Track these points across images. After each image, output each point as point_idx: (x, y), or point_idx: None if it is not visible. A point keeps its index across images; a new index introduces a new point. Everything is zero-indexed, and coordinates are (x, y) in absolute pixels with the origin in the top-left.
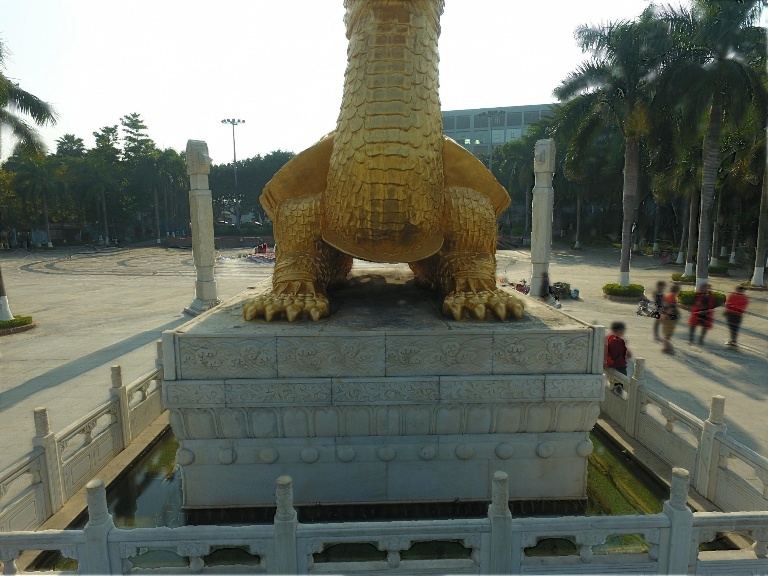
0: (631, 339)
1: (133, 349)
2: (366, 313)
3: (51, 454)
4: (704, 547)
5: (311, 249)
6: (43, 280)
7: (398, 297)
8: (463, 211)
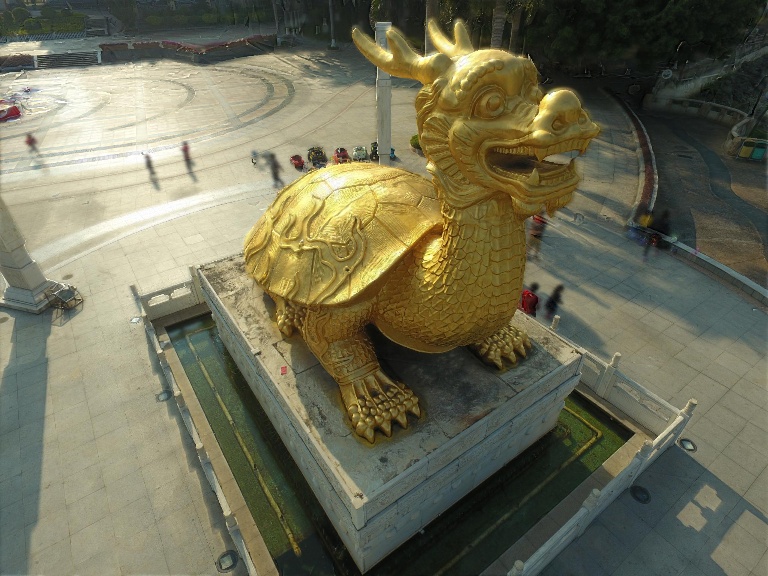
0: None
1: (42, 414)
2: (430, 380)
3: None
4: (607, 426)
5: (357, 334)
6: None
7: None
8: None
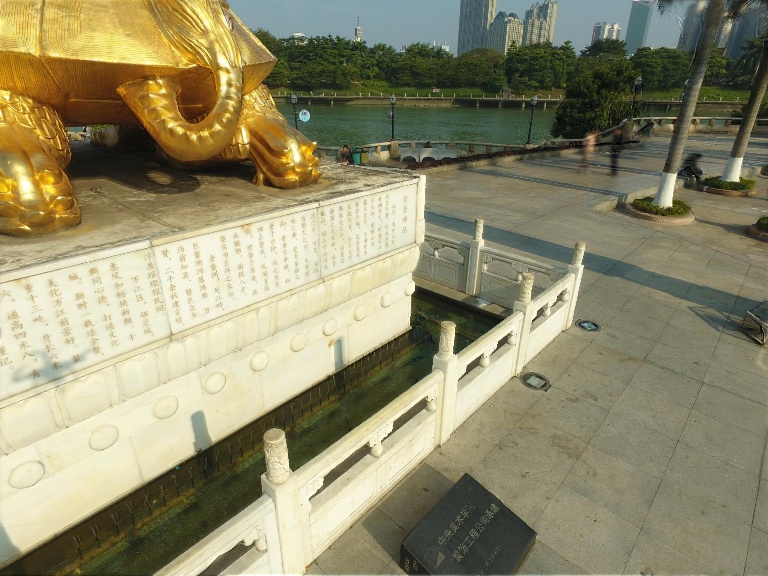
0: None
1: (519, 248)
2: None
3: None
4: None
5: None
6: None
7: None
8: None
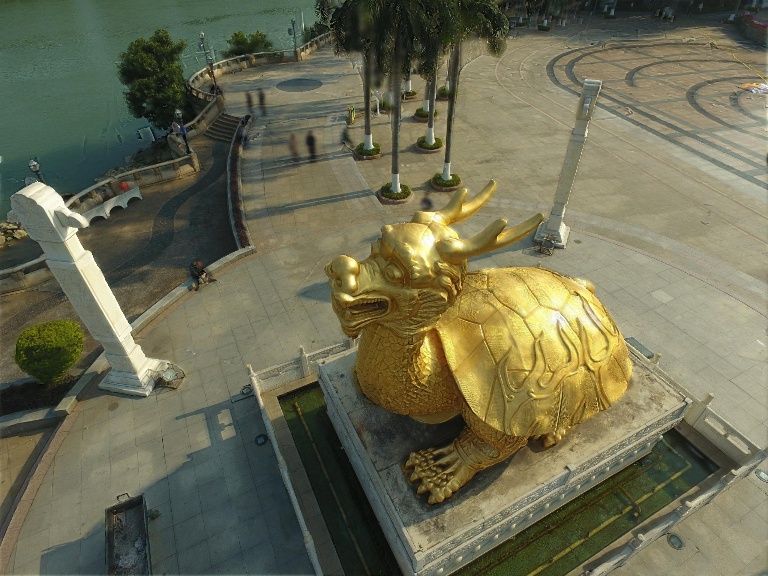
0: None
1: None
2: None
3: (304, 361)
4: None
5: None
6: (538, 98)
7: None
8: (464, 417)
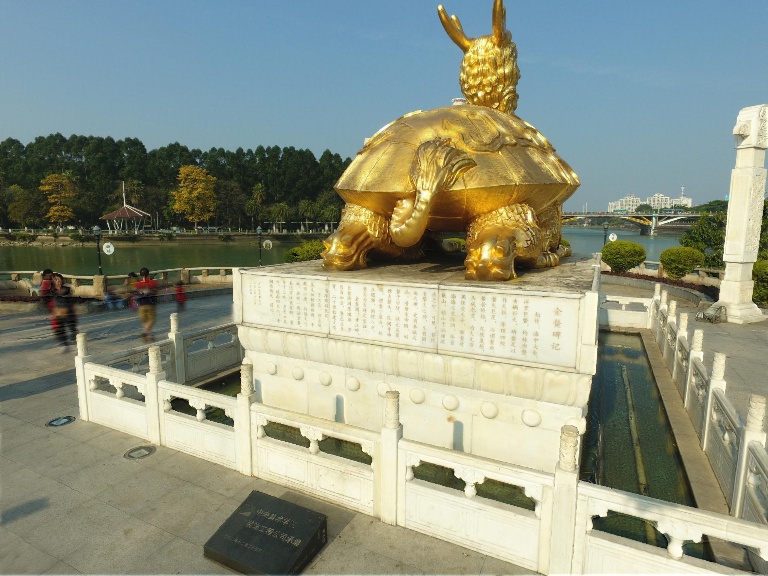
0: (73, 357)
1: None
2: None
3: None
4: None
5: None
6: None
7: (462, 257)
8: None
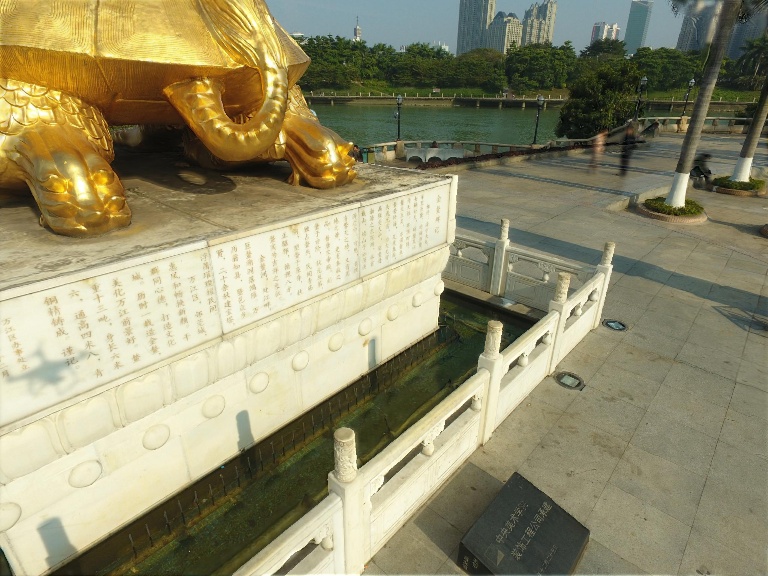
0: None
1: (537, 248)
2: None
3: None
4: None
5: None
6: None
7: None
8: None
